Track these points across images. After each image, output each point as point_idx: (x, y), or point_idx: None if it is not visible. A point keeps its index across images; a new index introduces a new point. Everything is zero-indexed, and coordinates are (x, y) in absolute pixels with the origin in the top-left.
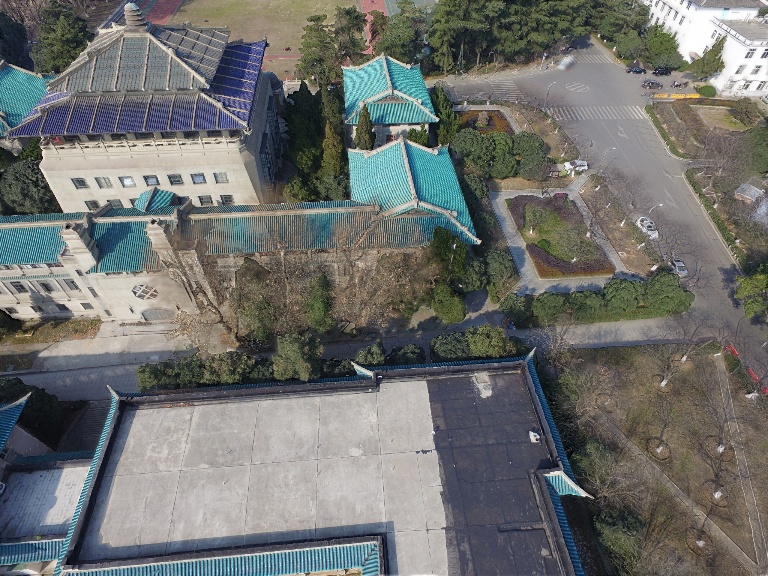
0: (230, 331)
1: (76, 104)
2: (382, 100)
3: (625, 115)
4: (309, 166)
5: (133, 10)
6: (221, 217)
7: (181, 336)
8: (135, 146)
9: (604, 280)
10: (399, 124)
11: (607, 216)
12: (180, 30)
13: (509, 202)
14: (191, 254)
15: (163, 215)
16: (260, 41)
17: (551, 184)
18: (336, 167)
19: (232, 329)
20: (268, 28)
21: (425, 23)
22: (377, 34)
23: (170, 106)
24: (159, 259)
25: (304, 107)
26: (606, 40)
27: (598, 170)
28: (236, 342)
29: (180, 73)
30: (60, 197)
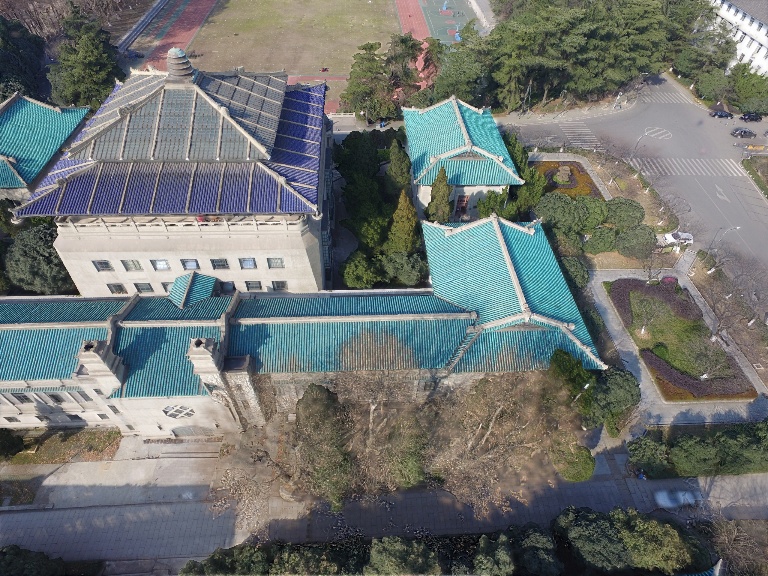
0: (288, 479)
1: (102, 173)
2: (457, 156)
3: (720, 171)
4: (376, 241)
5: (178, 57)
6: (278, 322)
7: (220, 464)
8: (173, 225)
9: (744, 406)
10: (475, 185)
11: (728, 310)
12: (231, 77)
13: (608, 287)
14: (241, 375)
15: (207, 320)
16: (319, 85)
17: (653, 262)
18: (407, 242)
19: (291, 477)
20: (302, 45)
21: (490, 55)
22: (431, 63)
23: (219, 179)
24: (200, 380)
25: (364, 160)
26: (681, 76)
27: (712, 249)
28: (292, 486)
29: (234, 138)
30: (77, 279)
